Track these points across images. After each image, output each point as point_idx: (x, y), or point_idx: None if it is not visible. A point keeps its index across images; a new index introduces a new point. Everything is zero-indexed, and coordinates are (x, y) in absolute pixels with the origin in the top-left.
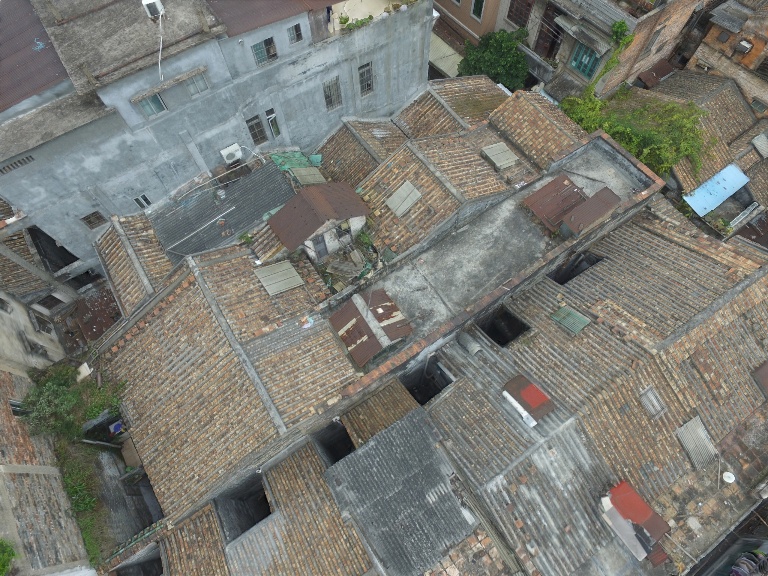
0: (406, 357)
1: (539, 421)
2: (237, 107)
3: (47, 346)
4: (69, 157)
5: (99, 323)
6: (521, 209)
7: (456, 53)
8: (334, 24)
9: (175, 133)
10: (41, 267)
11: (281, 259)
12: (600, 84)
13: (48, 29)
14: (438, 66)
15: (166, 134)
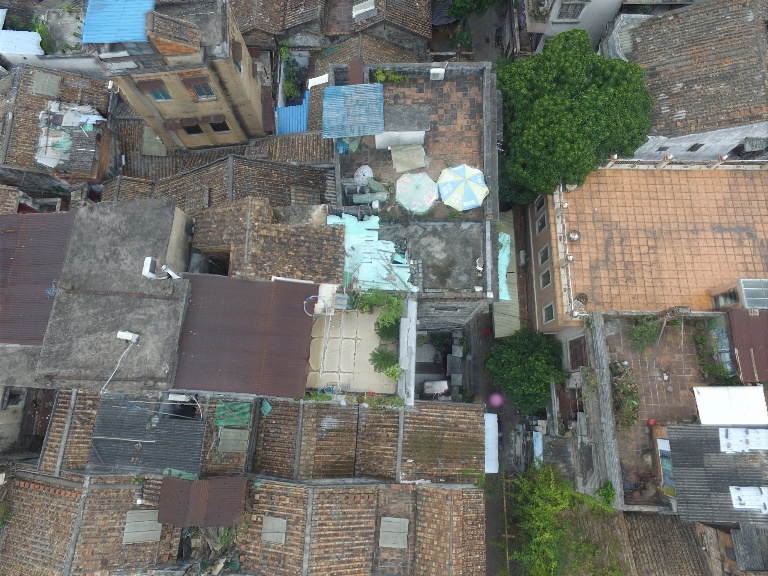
0: None
1: None
2: None
3: (4, 422)
4: None
5: None
6: None
7: (516, 317)
8: (314, 359)
9: None
10: None
11: None
12: (582, 488)
13: (58, 290)
14: (494, 313)
15: None
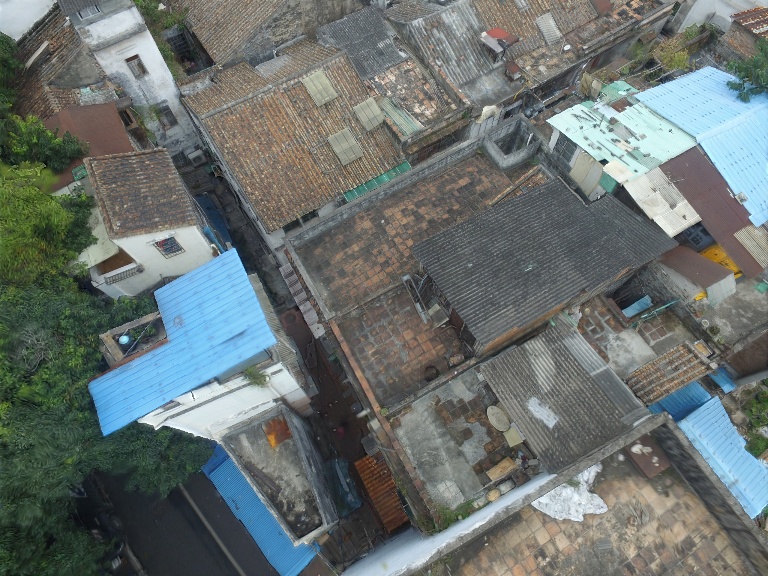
0: None
1: (448, 1)
2: None
3: None
4: None
5: None
6: None
7: None
8: None
9: None
10: None
11: None
12: None
13: None
14: None
15: None
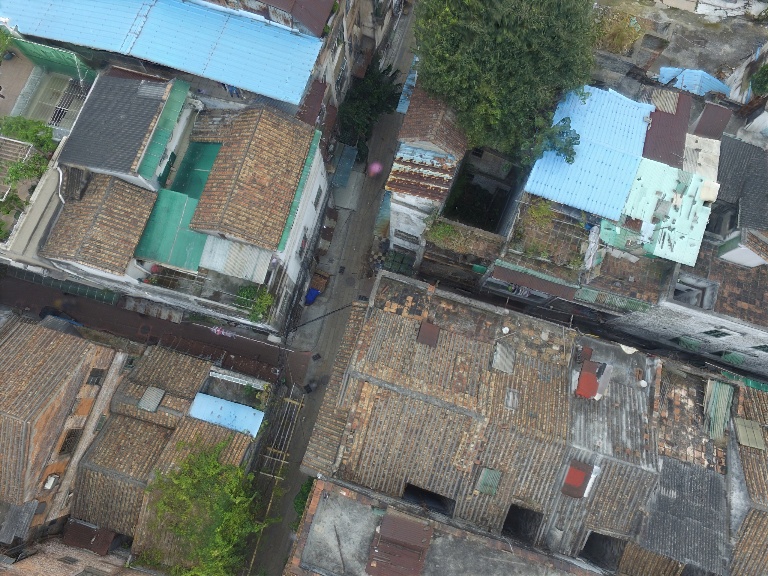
0: None
1: None
2: None
3: None
4: None
5: None
6: None
7: None
8: None
9: None
10: None
11: None
12: None
13: None
14: None
15: None
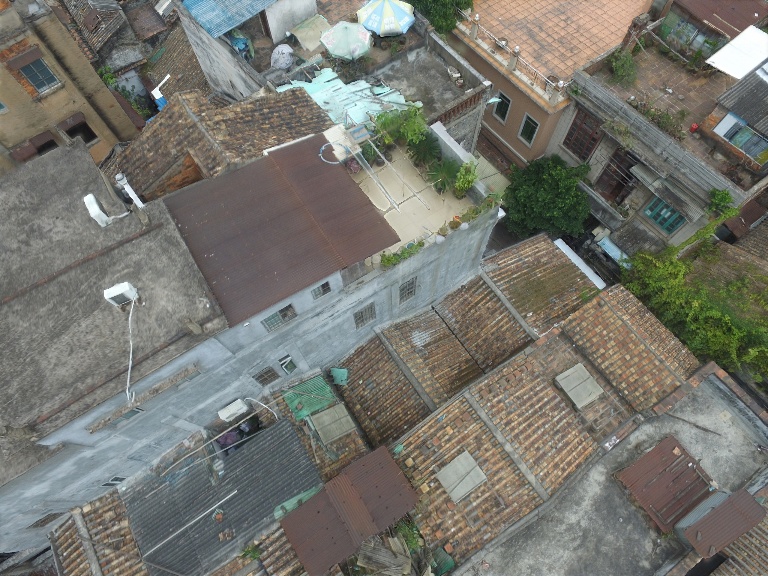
0: None
1: None
2: (241, 372)
3: None
4: (0, 500)
5: None
6: (615, 481)
7: (497, 173)
8: None
9: (155, 422)
10: None
11: (298, 567)
12: None
13: None
14: None
15: (143, 428)
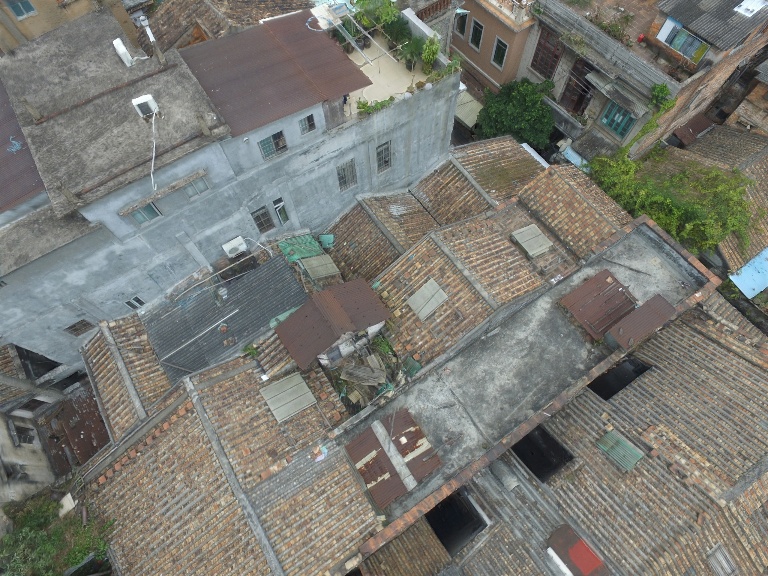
0: (435, 502)
1: None
2: (241, 202)
3: (28, 463)
4: (48, 276)
5: (87, 428)
6: (558, 308)
7: (474, 100)
8: (349, 101)
9: (171, 236)
10: (21, 374)
11: (290, 370)
12: (634, 145)
13: (24, 129)
14: None
15: (161, 238)
